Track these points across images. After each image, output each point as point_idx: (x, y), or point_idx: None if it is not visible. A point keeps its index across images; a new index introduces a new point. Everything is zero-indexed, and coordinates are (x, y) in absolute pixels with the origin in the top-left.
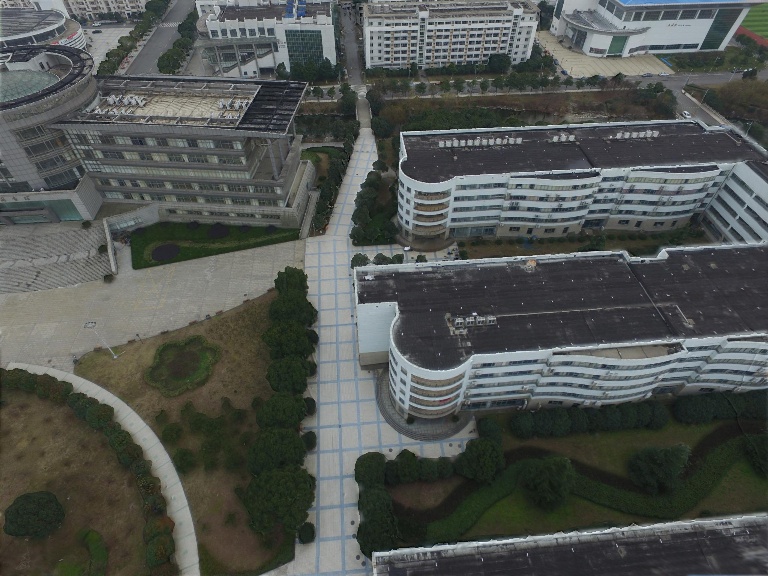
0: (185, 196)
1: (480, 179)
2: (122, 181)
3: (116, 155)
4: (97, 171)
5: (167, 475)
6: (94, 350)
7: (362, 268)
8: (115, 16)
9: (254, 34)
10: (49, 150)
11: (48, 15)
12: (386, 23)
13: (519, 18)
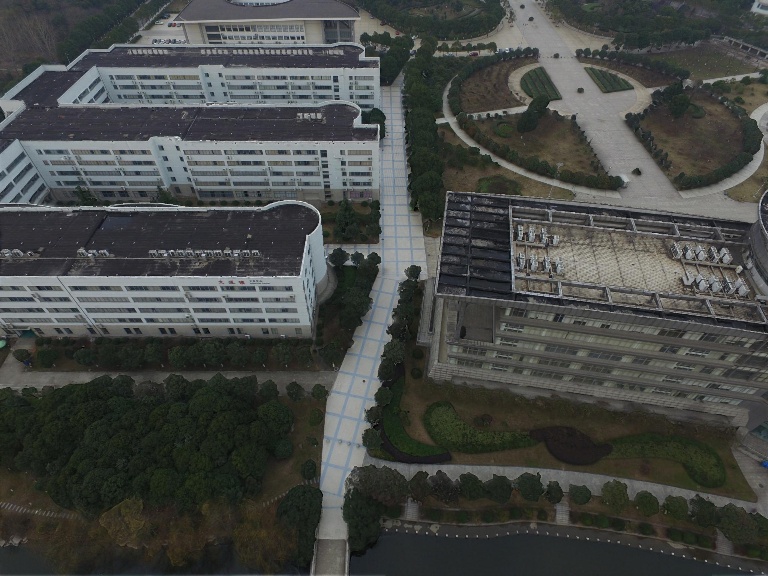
0: None
1: (239, 211)
2: None
3: None
4: None
5: (481, 151)
6: None
7: (373, 142)
8: None
9: None
10: None
11: None
12: None
13: None
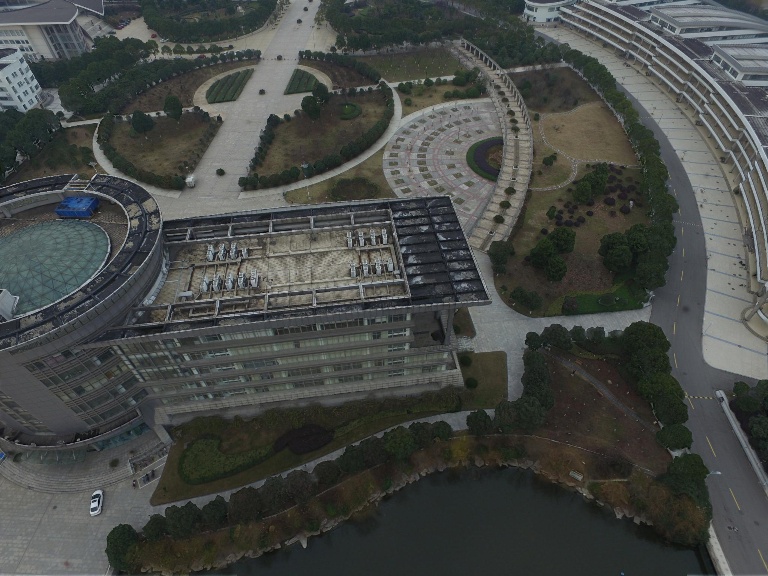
0: None
1: None
2: None
3: None
4: None
5: (98, 151)
6: None
7: None
8: None
9: None
10: None
11: None
12: None
13: None
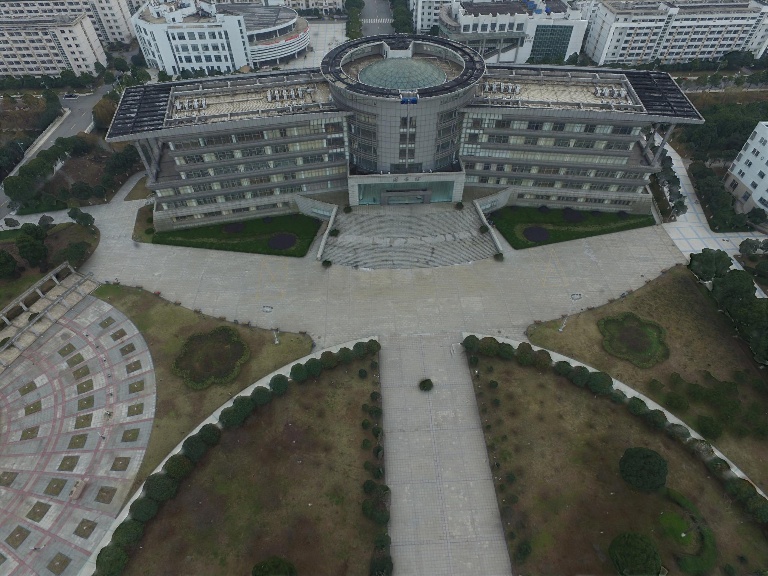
0: (544, 181)
1: None
2: (489, 165)
3: (501, 139)
4: (470, 155)
5: None
6: (535, 323)
7: None
8: (314, 12)
9: (503, 29)
10: (451, 133)
11: (278, 10)
12: (634, 19)
13: (765, 15)
